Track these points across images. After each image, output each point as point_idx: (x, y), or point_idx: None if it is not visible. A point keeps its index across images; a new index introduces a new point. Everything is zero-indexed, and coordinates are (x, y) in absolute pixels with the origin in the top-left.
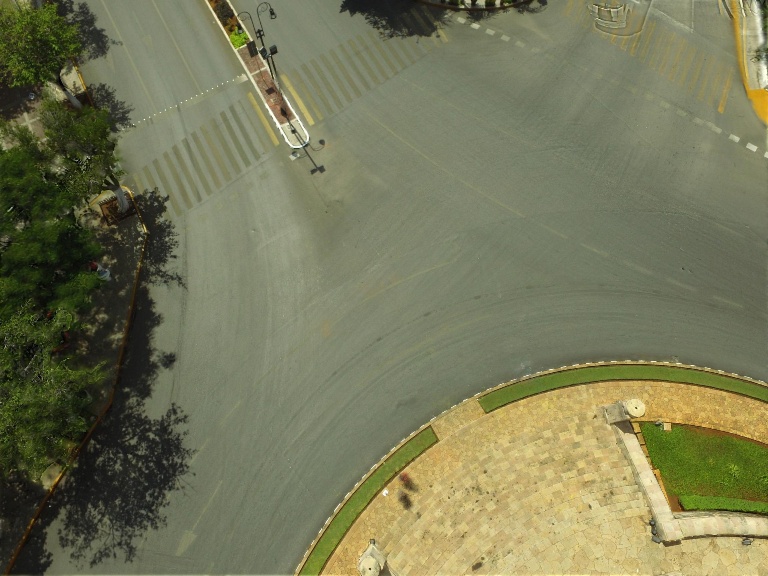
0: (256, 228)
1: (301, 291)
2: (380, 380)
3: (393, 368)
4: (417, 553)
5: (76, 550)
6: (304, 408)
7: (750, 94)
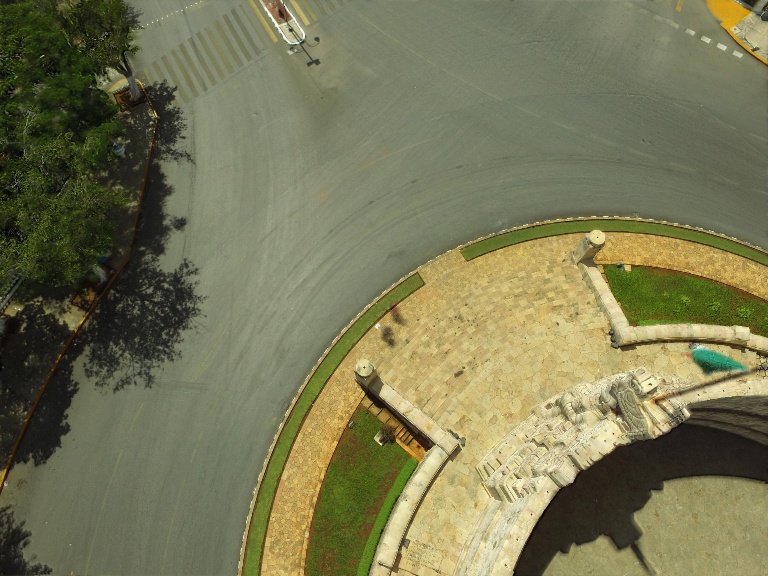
0: (258, 112)
1: (300, 164)
2: (372, 236)
3: (384, 226)
4: (406, 370)
5: (100, 380)
6: (304, 260)
7: None
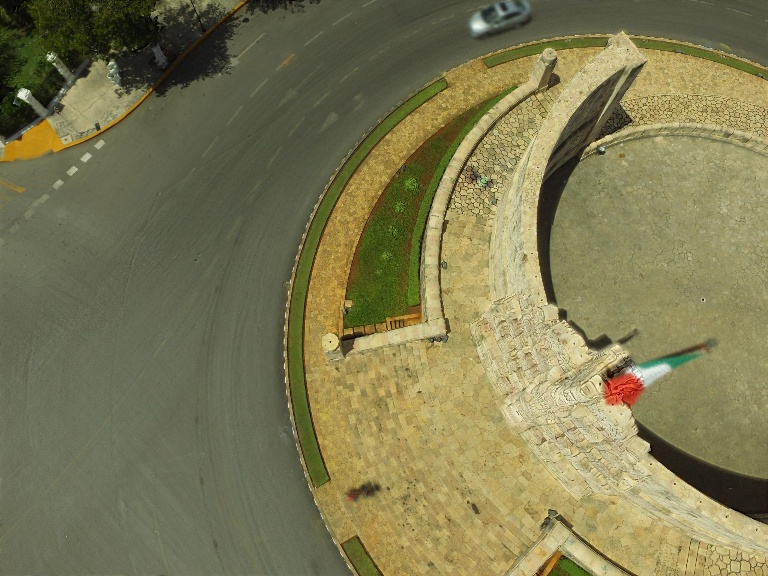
0: None
1: None
2: None
3: None
4: (466, 569)
5: None
6: None
7: (8, 159)
